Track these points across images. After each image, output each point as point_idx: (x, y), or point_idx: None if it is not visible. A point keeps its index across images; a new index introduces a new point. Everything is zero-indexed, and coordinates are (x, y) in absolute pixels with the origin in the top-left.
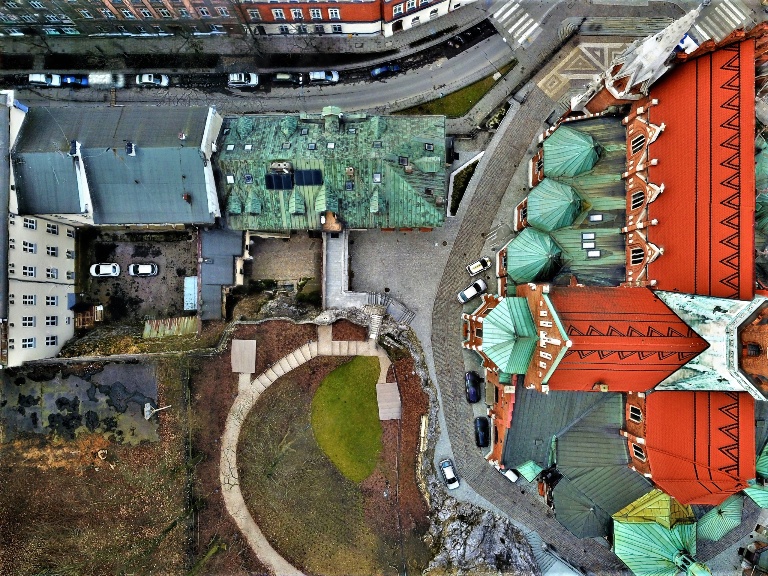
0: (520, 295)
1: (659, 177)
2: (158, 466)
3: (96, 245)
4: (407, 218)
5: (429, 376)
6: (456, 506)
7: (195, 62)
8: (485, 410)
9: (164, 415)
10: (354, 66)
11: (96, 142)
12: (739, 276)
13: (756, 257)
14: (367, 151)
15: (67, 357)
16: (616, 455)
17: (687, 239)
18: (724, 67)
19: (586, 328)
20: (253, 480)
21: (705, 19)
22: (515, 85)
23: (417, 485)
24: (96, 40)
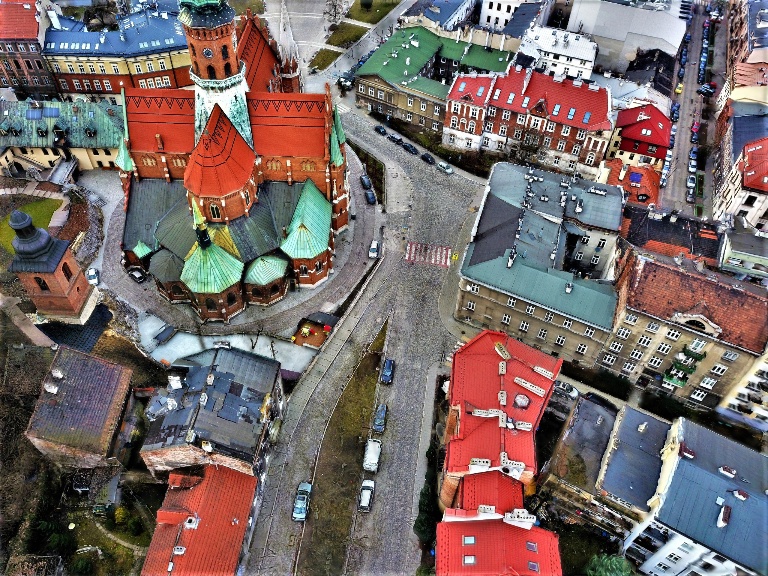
0: None
1: None
2: None
3: None
4: (108, 142)
5: (102, 229)
6: None
7: None
8: None
9: None
10: None
11: None
12: None
13: None
14: None
15: None
16: (186, 213)
17: None
18: None
19: None
20: None
21: None
22: None
23: None
24: None
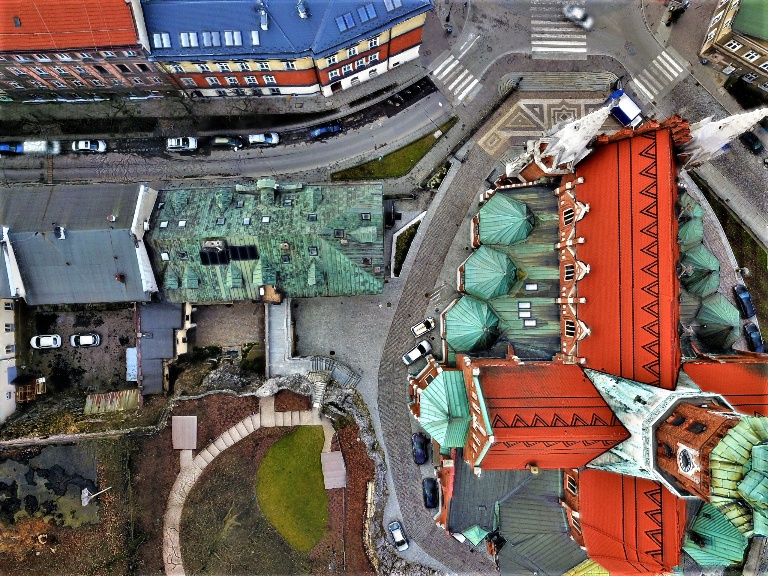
0: (459, 365)
1: (586, 255)
2: (100, 548)
3: (36, 316)
4: (347, 287)
5: (376, 439)
6: (406, 568)
7: (133, 126)
8: (432, 471)
9: (104, 497)
10: (294, 127)
11: (24, 226)
12: (659, 364)
13: (682, 333)
14: (302, 225)
15: (4, 440)
16: (556, 523)
17: (612, 321)
18: (642, 154)
19: (511, 418)
20: (197, 558)
21: (643, 72)
22: (456, 143)
23: (364, 551)
24: (31, 106)
